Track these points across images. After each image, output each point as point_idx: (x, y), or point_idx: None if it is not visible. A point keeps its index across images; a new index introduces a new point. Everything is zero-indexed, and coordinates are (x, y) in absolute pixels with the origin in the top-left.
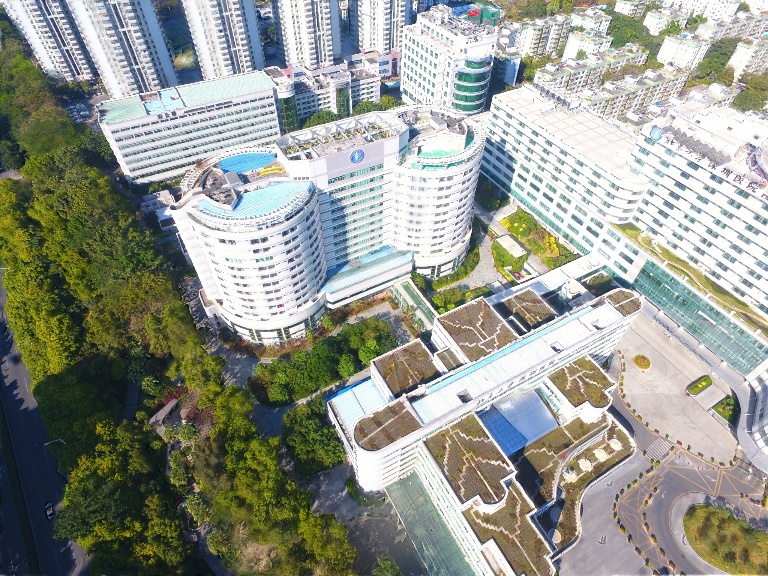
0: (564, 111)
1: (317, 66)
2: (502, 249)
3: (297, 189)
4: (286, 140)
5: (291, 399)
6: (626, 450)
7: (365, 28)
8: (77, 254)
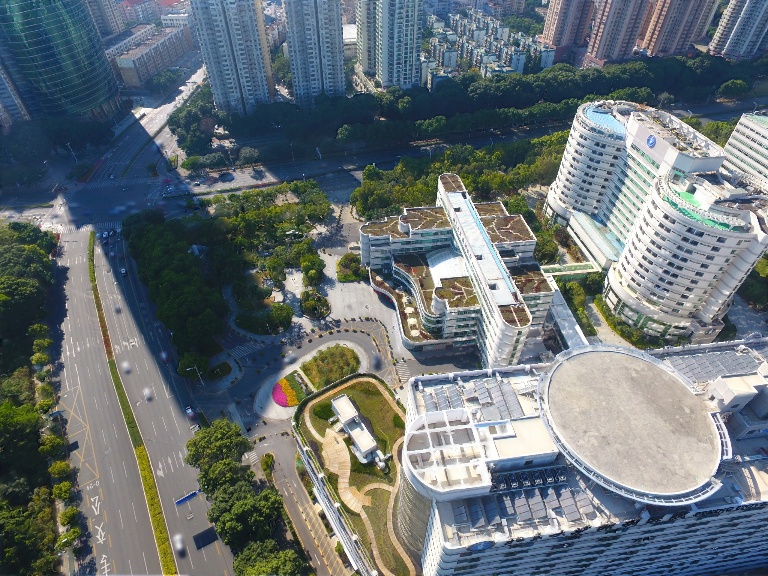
0: None
1: None
2: None
3: (616, 129)
4: (666, 117)
5: None
6: (409, 336)
7: None
8: None
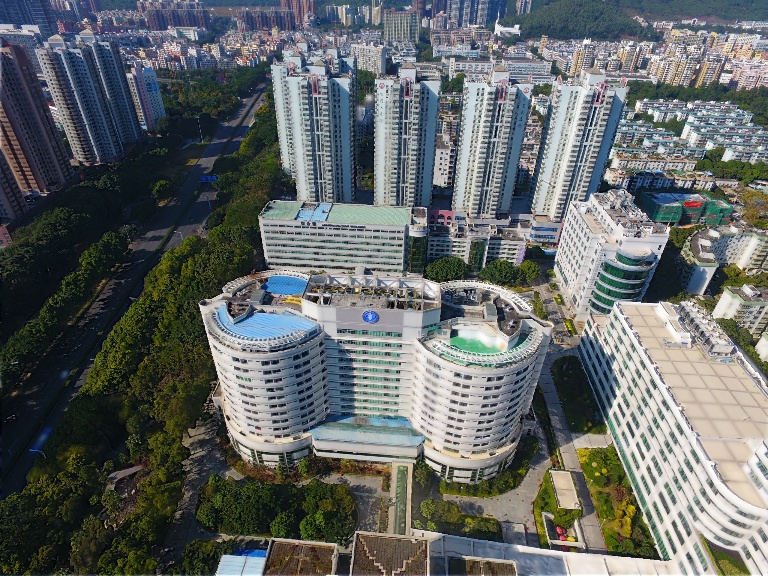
0: (703, 352)
1: (477, 216)
2: (550, 487)
3: (300, 326)
4: (324, 278)
5: (216, 528)
6: None
7: (541, 193)
8: (176, 308)
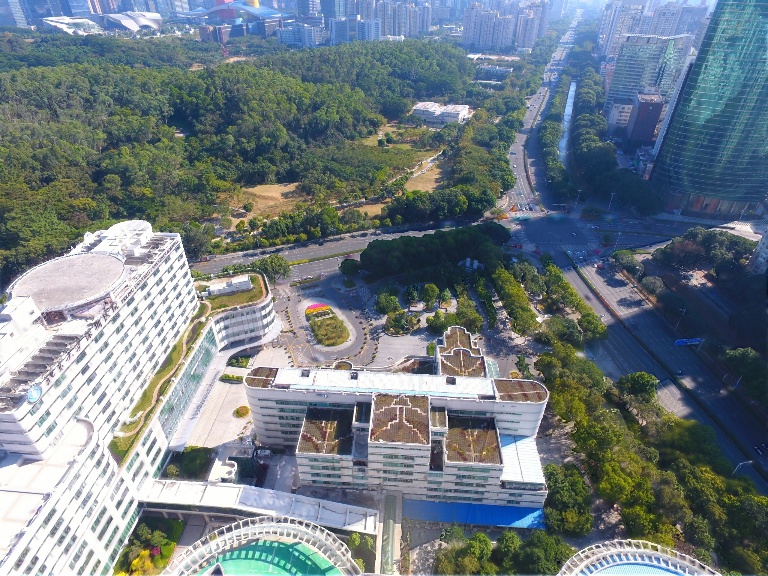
0: None
1: None
2: None
3: None
4: None
5: None
6: None
7: None
8: None
